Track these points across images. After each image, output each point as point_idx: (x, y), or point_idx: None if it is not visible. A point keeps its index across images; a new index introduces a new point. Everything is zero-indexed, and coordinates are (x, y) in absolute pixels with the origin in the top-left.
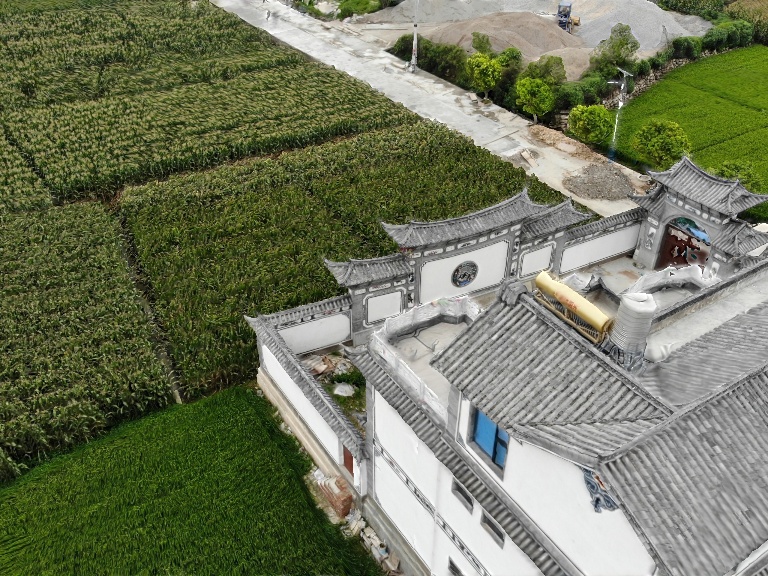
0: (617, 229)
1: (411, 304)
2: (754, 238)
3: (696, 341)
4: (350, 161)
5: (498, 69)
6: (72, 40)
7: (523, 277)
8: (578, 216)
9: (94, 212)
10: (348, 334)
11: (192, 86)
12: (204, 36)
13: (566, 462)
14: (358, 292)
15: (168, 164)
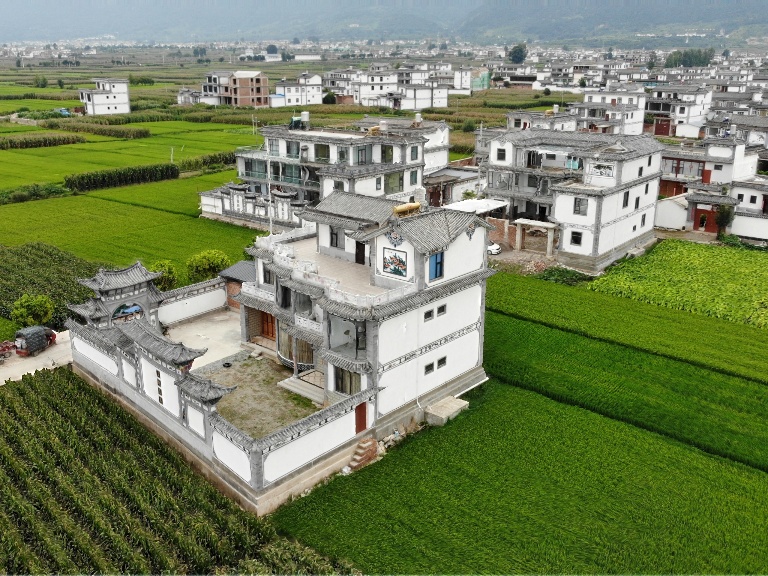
0: None
1: None
2: None
3: (382, 222)
4: None
5: None
6: None
7: None
8: None
9: None
10: None
11: None
12: None
13: (461, 234)
14: None
15: None
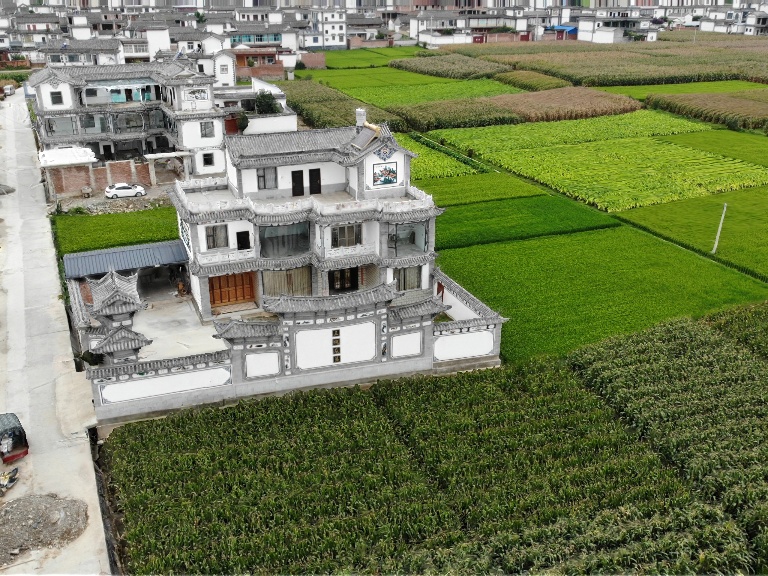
0: None
1: None
2: None
3: None
4: (395, 572)
5: None
6: None
7: None
8: None
9: (755, 508)
10: None
11: None
12: None
13: None
14: None
15: None
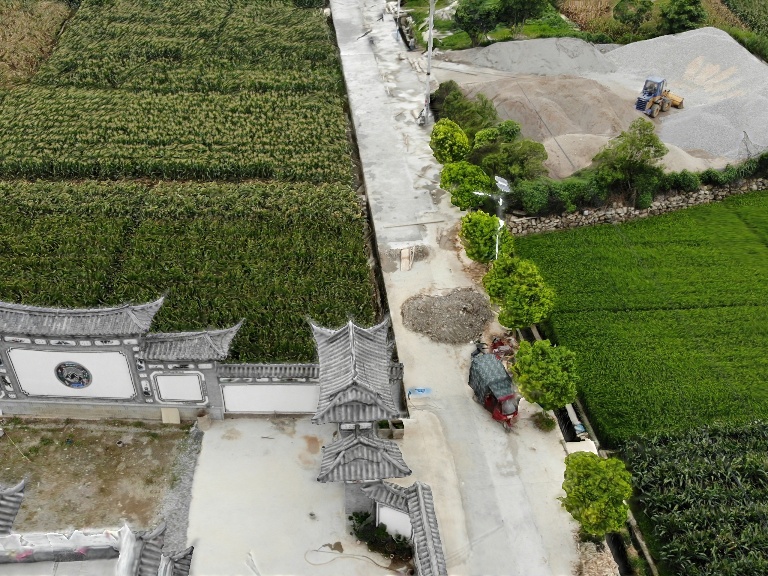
0: (313, 382)
1: (10, 388)
2: (376, 464)
3: None
4: None
5: (460, 143)
6: (158, 29)
7: (165, 401)
8: (213, 352)
9: None
10: None
11: (186, 94)
12: (272, 46)
13: None
14: None
15: (68, 167)
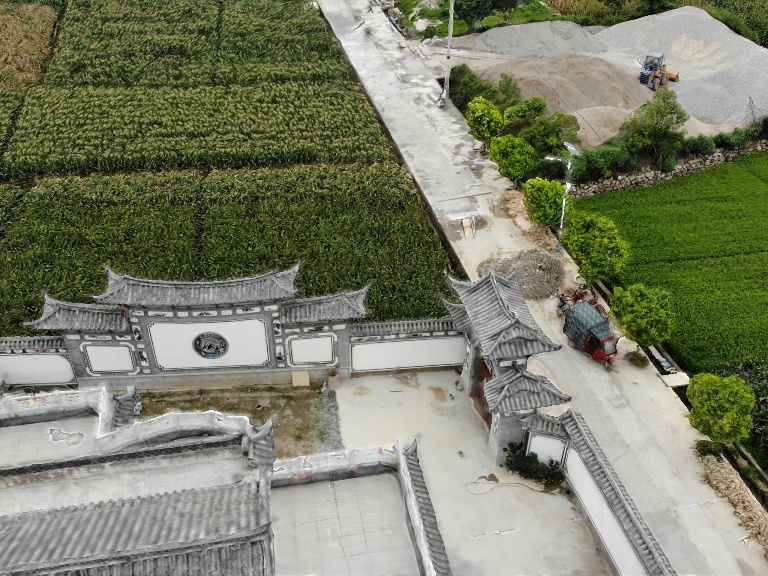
0: (436, 336)
1: (146, 363)
2: (537, 394)
3: None
4: None
5: (496, 119)
6: (156, 28)
7: (296, 364)
8: (352, 311)
9: (2, 195)
10: (73, 377)
11: (208, 88)
12: (274, 39)
13: None
14: (71, 337)
15: (114, 161)
